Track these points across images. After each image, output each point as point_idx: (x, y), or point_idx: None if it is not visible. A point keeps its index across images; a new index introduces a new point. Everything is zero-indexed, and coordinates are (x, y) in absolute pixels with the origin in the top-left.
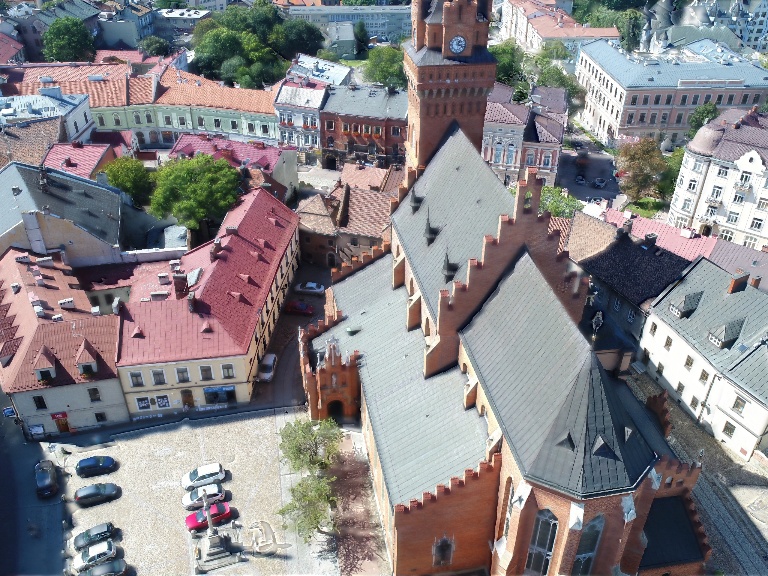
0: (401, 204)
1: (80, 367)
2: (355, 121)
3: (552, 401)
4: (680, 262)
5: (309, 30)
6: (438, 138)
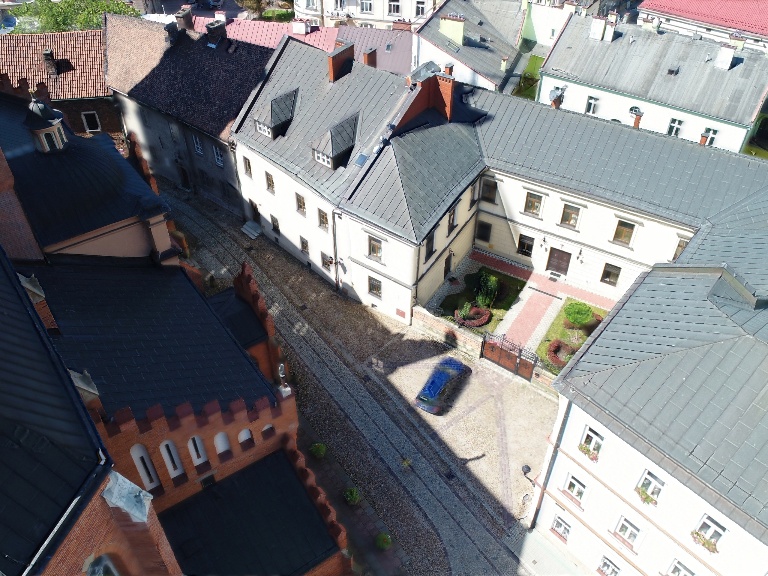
0: None
1: None
2: None
3: None
4: (263, 54)
5: None
6: None
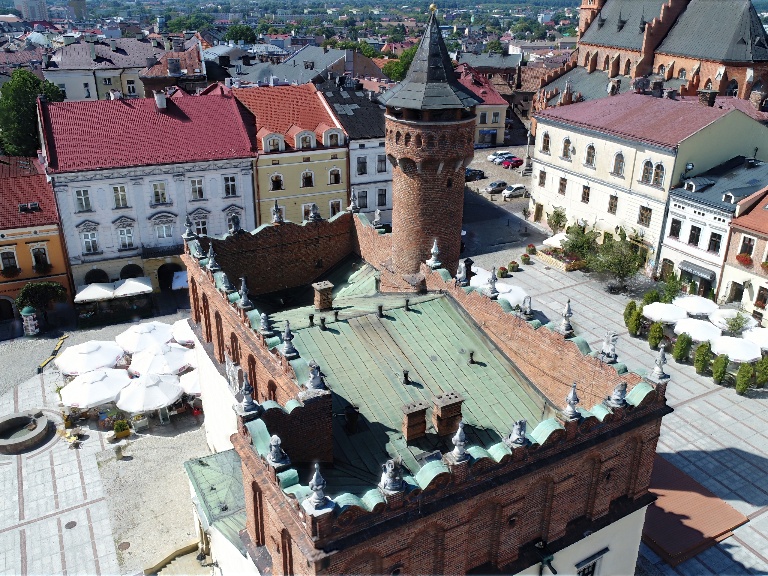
0: (586, 32)
1: None
2: (482, 71)
3: (730, 30)
4: None
5: None
6: None
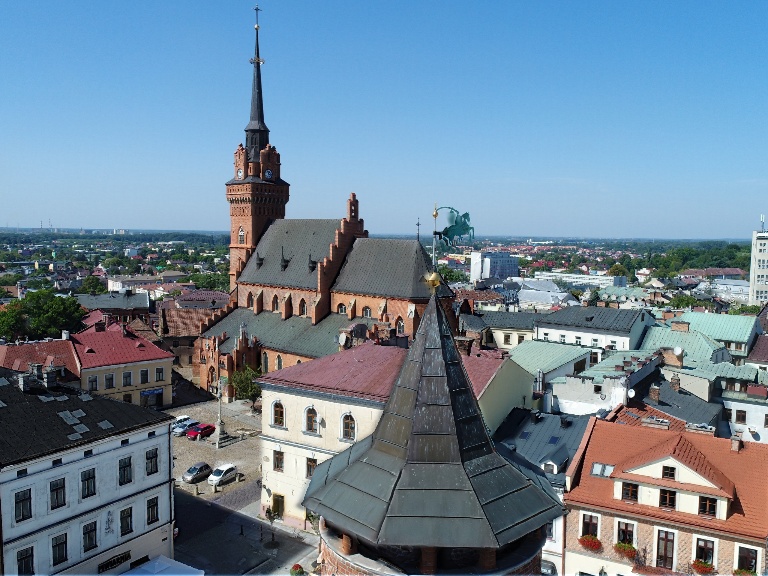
0: (243, 272)
1: None
2: None
3: (408, 268)
4: None
5: None
6: (261, 229)
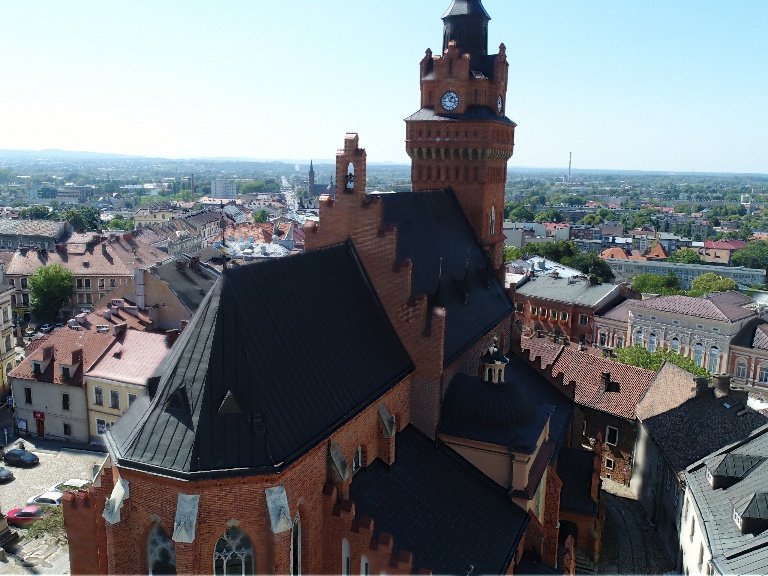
0: None
1: (61, 368)
2: (543, 304)
3: None
4: (764, 424)
5: (597, 265)
6: None
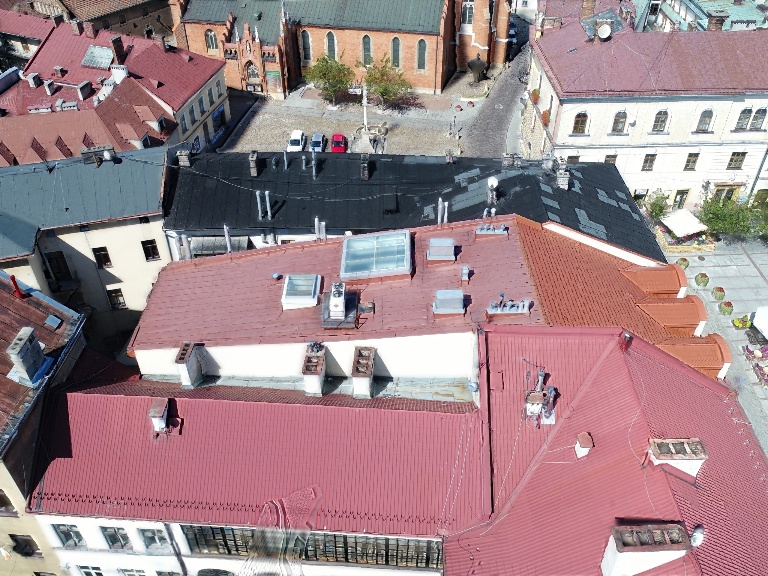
0: None
1: (159, 125)
2: None
3: None
4: None
5: None
6: None
